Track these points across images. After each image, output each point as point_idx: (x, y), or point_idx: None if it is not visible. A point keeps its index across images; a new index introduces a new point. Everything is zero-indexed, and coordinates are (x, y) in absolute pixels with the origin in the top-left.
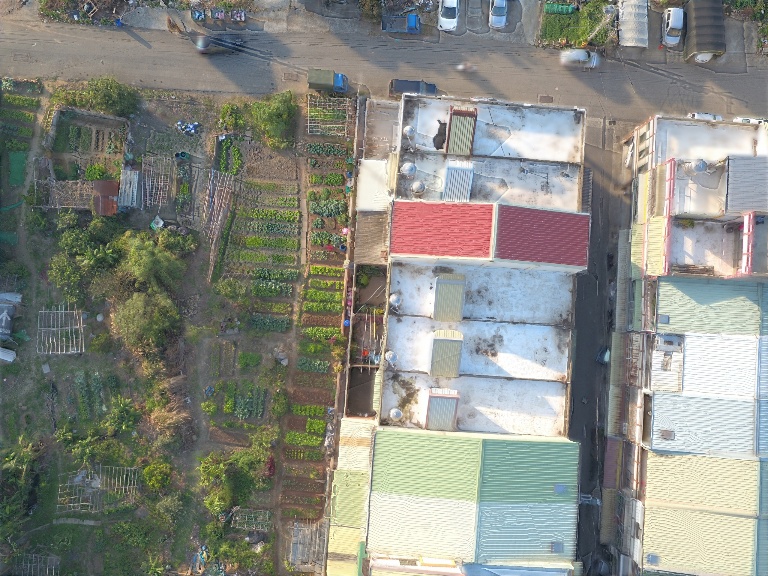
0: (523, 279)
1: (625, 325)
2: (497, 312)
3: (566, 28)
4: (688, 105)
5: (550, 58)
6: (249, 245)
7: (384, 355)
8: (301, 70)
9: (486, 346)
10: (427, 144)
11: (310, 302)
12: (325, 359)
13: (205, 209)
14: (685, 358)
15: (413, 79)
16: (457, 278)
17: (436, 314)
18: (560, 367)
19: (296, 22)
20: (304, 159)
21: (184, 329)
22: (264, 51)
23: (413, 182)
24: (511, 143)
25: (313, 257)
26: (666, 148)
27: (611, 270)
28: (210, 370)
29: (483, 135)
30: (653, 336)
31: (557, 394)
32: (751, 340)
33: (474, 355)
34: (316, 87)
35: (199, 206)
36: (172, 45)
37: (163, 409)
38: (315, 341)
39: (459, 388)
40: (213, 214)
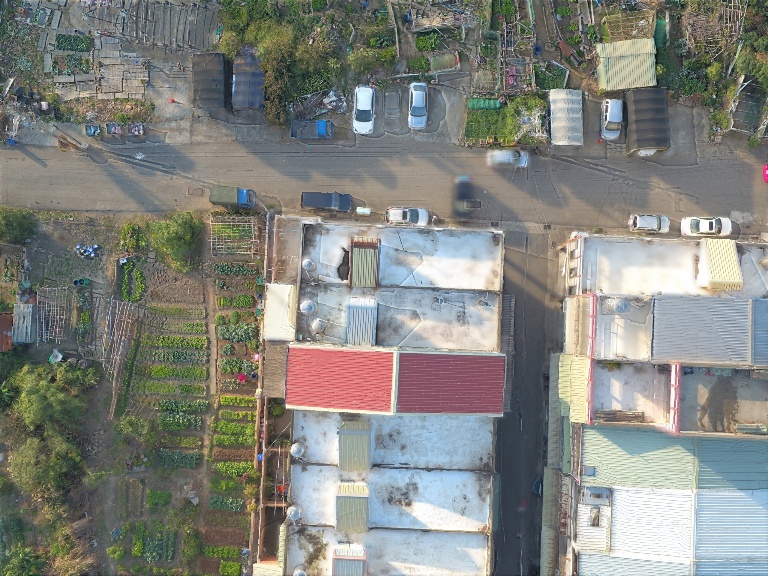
0: (439, 420)
1: (557, 460)
2: (410, 457)
3: (494, 124)
4: (631, 204)
5: (477, 158)
6: (155, 376)
7: (286, 511)
8: (206, 184)
9: (399, 495)
10: (331, 275)
11: (221, 435)
12: (238, 496)
13: (104, 342)
14: (613, 514)
15: (328, 188)
16: (361, 428)
17: (342, 464)
18: (481, 516)
19: (200, 131)
20: (212, 280)
21: (88, 468)
22: (166, 165)
23: (316, 318)
24: (423, 270)
25: (223, 386)
26: (596, 269)
27: (547, 391)
28: (117, 510)
29: (392, 262)
30: (579, 487)
31: (478, 545)
32: (686, 495)
33: (386, 505)
34: (221, 204)
35: (101, 335)
36: (69, 162)
37: (66, 556)
38: (227, 477)
39: (370, 541)
40: (113, 347)
